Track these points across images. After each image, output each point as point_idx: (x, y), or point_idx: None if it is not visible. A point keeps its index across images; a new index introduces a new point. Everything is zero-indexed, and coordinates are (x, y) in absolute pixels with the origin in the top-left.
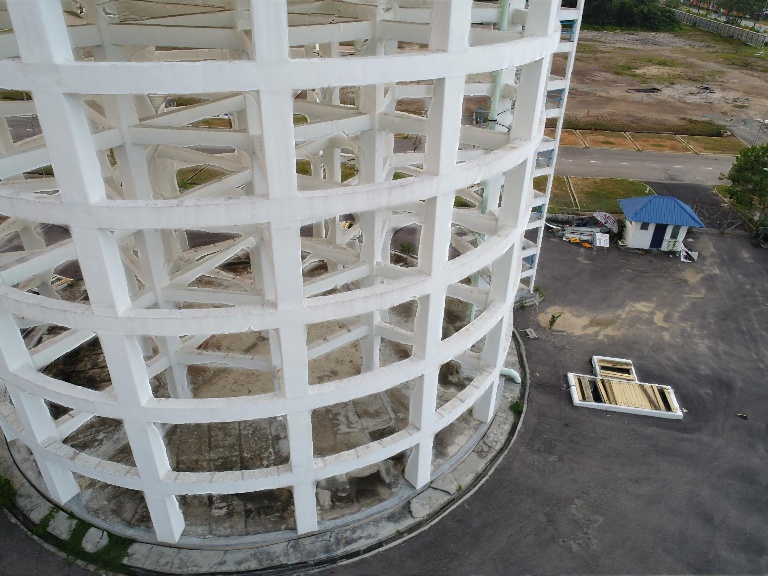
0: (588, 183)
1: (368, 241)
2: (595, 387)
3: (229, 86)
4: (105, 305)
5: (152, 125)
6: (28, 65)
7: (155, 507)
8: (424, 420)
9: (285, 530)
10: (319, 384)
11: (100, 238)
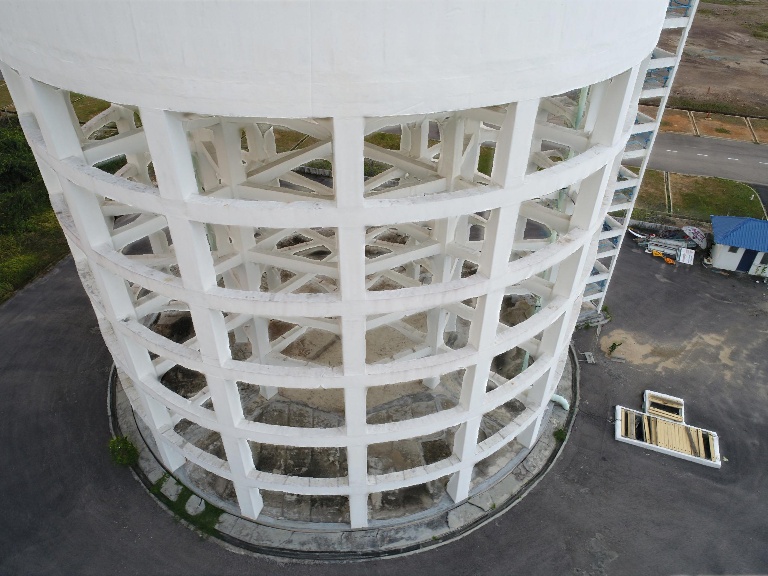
0: (688, 182)
1: (437, 280)
2: (640, 424)
3: (314, 224)
4: (212, 358)
5: (257, 183)
6: (165, 200)
7: (241, 493)
8: (465, 454)
9: (341, 523)
10: (375, 425)
11: (210, 315)
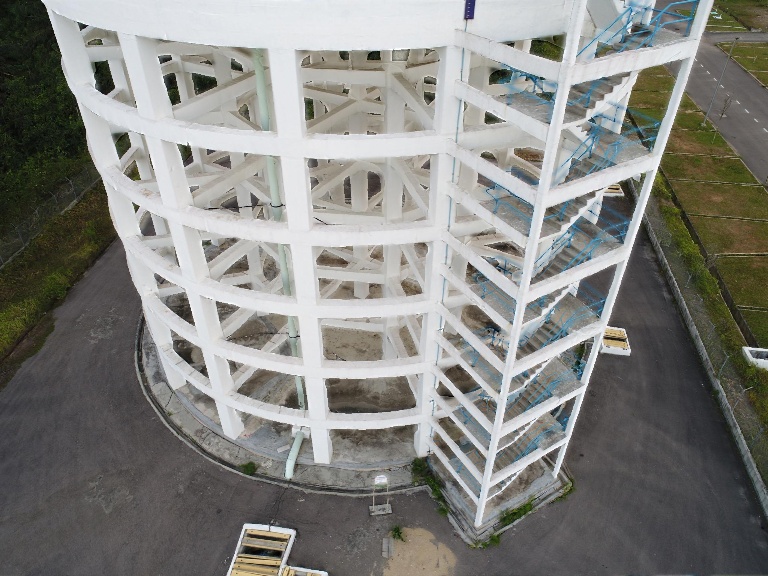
0: None
1: None
2: None
3: None
4: None
5: None
6: None
7: None
8: None
9: None
10: None
11: None
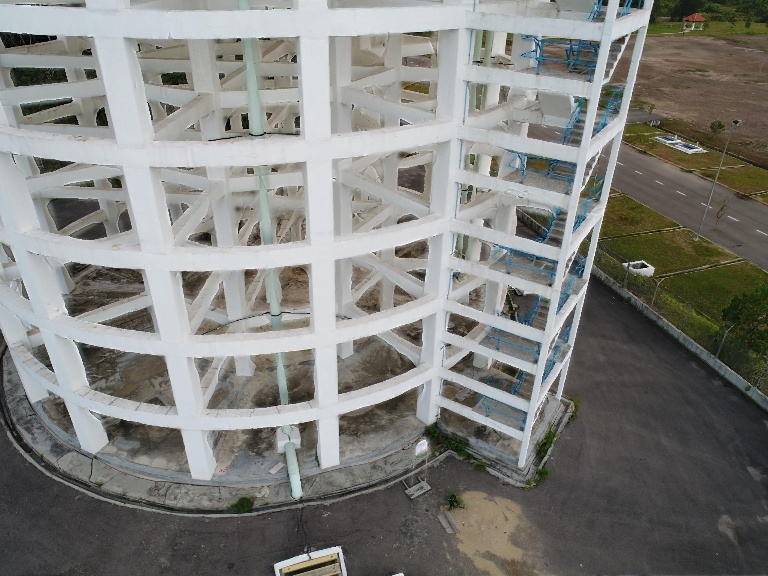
0: None
1: None
2: None
3: None
4: None
5: None
6: None
7: None
8: (59, 379)
9: None
10: None
11: None
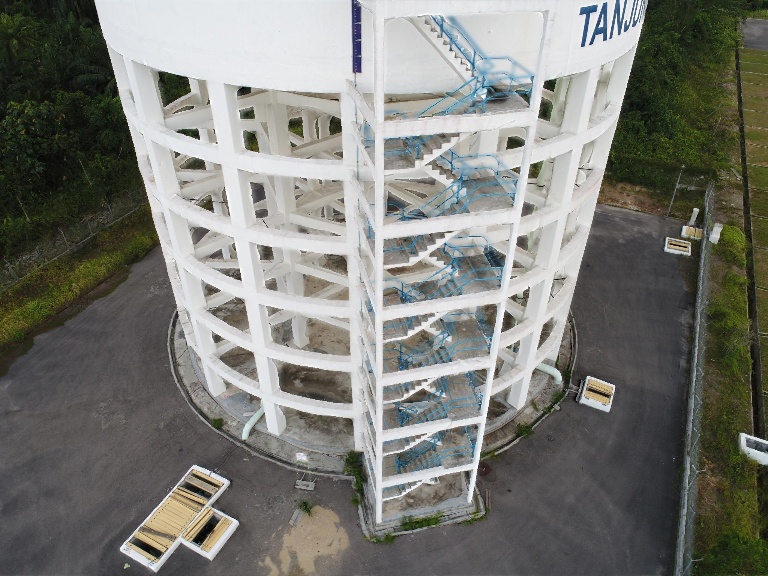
0: None
1: None
2: None
3: None
4: None
5: None
6: None
7: None
8: None
9: None
10: None
11: None
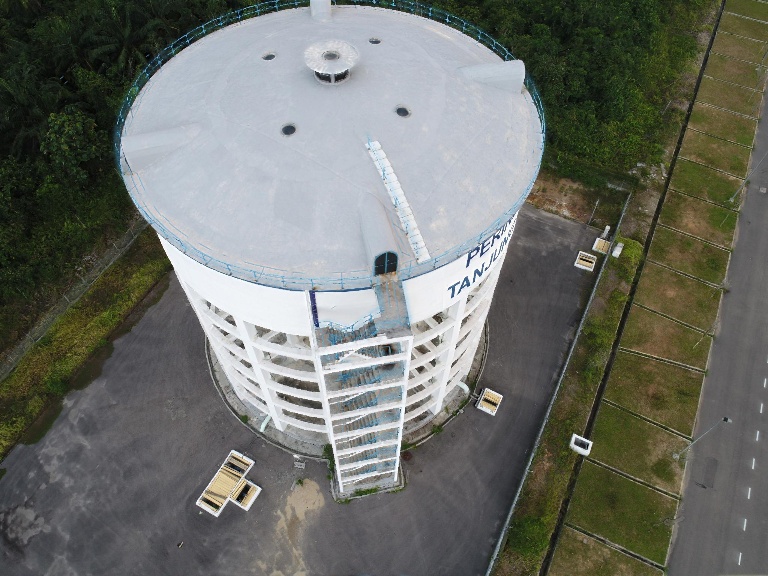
0: None
1: None
2: None
3: None
4: None
5: None
6: None
7: None
8: None
9: None
10: None
11: None
